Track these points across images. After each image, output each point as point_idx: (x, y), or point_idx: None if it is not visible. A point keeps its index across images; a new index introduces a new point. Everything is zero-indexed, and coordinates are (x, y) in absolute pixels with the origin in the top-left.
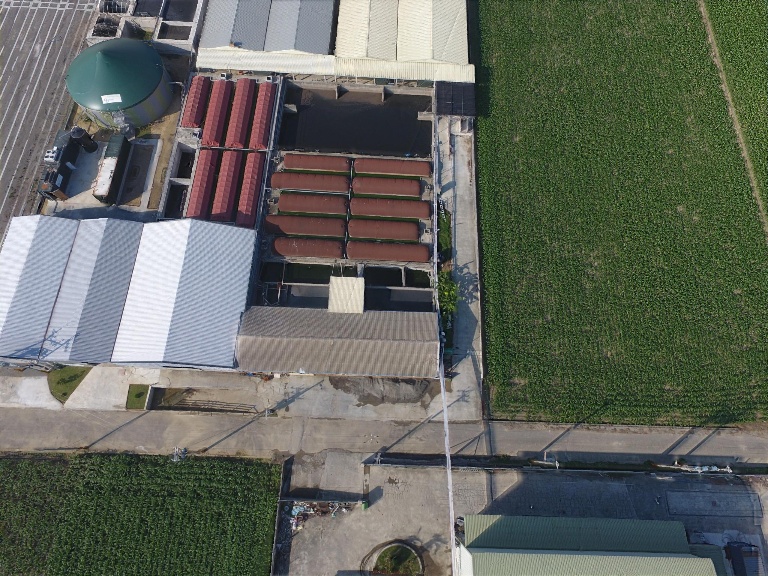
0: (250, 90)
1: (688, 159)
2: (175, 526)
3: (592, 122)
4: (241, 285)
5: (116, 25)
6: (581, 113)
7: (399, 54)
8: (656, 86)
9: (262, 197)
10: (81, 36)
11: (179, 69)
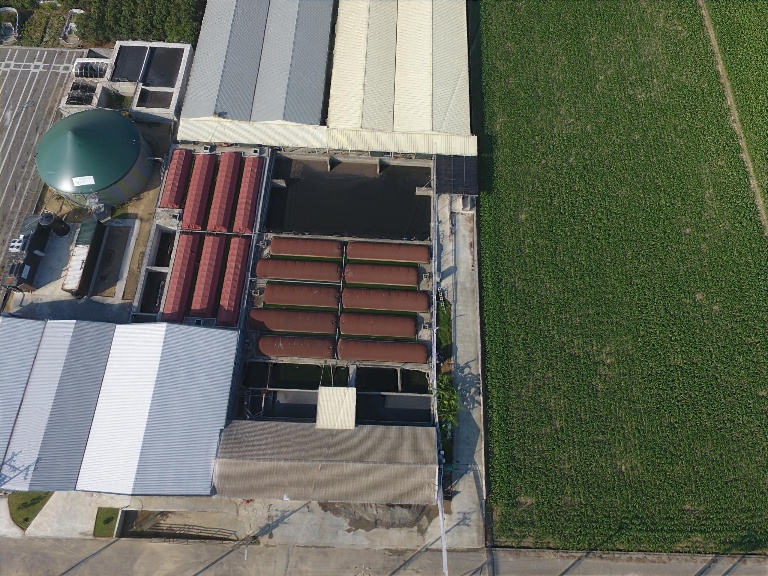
0: (235, 165)
1: (707, 240)
2: None
3: (603, 197)
4: (221, 397)
5: (92, 92)
6: (591, 187)
7: (396, 124)
8: (672, 156)
9: (246, 288)
10: (55, 101)
11: (160, 139)
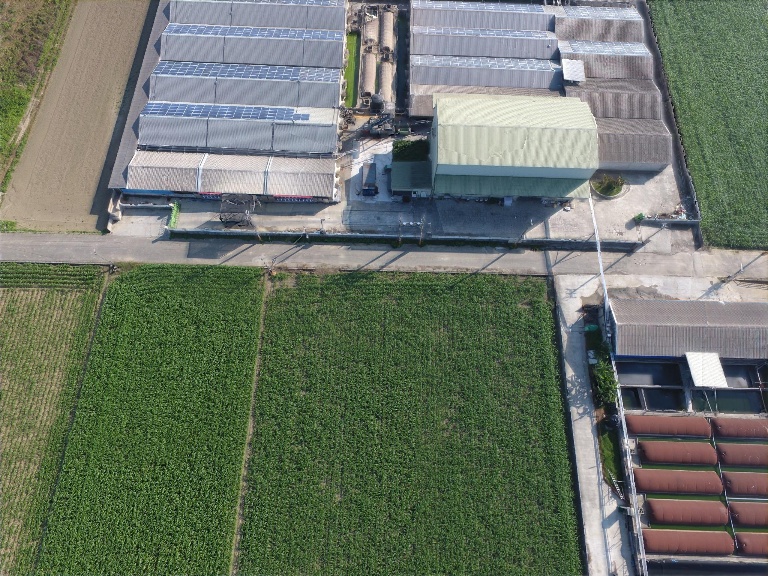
0: None
1: (312, 575)
2: (763, 208)
3: None
4: None
5: None
6: None
7: None
8: None
9: None
10: None
11: None
